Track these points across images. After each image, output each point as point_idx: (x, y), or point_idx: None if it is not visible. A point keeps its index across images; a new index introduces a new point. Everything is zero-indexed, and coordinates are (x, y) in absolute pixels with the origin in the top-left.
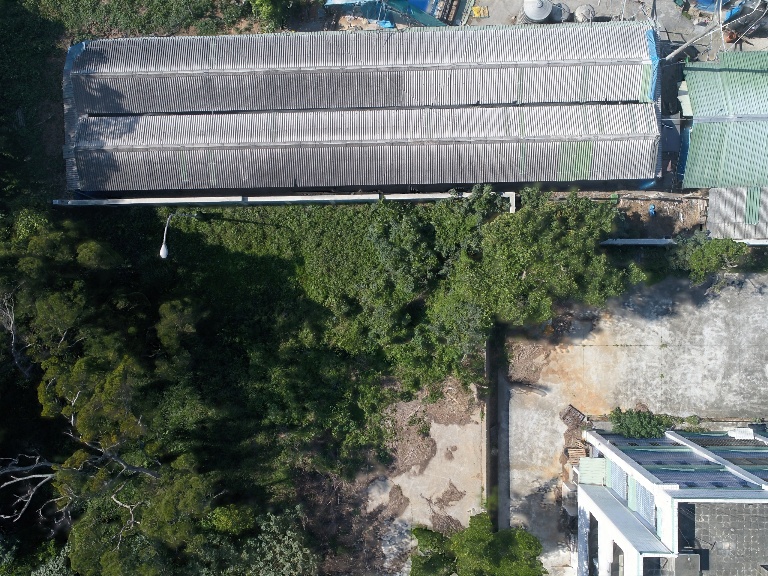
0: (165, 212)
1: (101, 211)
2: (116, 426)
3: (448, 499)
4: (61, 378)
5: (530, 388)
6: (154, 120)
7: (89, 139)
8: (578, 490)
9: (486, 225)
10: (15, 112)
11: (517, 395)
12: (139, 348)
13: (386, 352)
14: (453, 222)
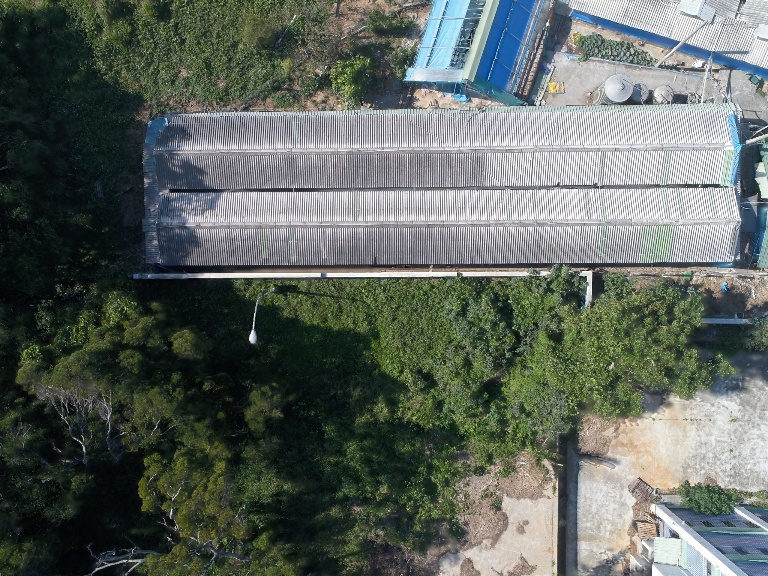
0: (242, 285)
1: (178, 283)
2: (213, 519)
3: (519, 573)
4: (164, 476)
5: (599, 461)
6: (235, 197)
7: (171, 215)
8: (653, 570)
9: (567, 308)
10: (94, 184)
11: (586, 467)
12: (228, 434)
13: (459, 426)
14: (532, 302)
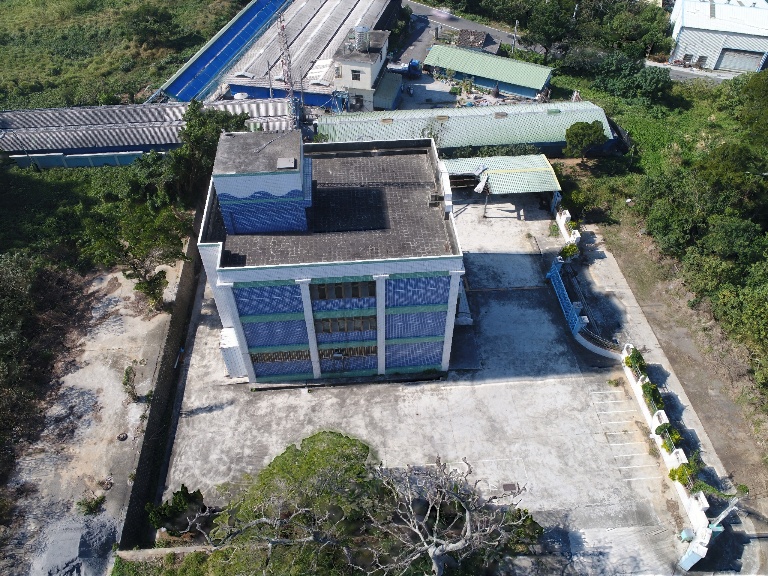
0: (16, 168)
1: None
2: None
3: None
4: None
5: None
6: None
7: None
8: None
9: None
10: None
11: None
12: None
13: None
14: None
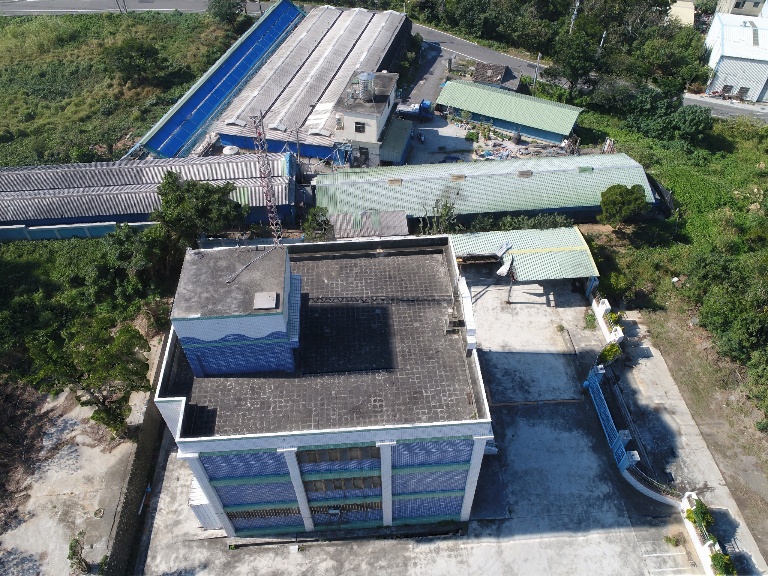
0: None
1: None
2: None
3: None
4: None
5: None
6: None
7: None
8: None
9: None
10: None
11: None
12: None
13: (97, 308)
14: None
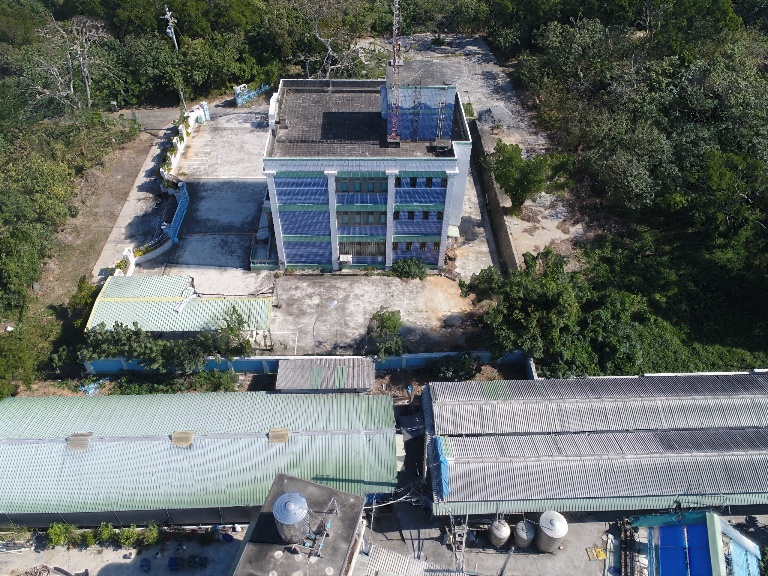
0: None
1: None
2: None
3: (532, 229)
4: None
5: None
6: None
7: None
8: None
9: None
10: None
11: None
12: None
13: None
14: None
